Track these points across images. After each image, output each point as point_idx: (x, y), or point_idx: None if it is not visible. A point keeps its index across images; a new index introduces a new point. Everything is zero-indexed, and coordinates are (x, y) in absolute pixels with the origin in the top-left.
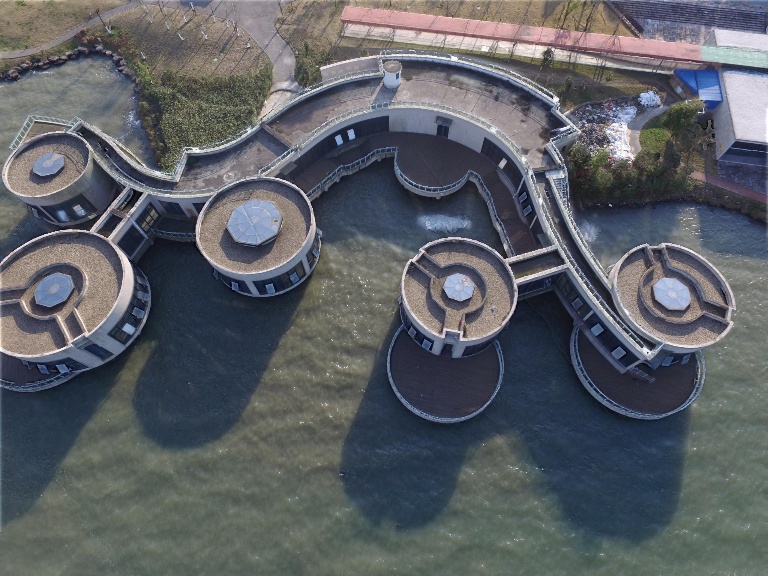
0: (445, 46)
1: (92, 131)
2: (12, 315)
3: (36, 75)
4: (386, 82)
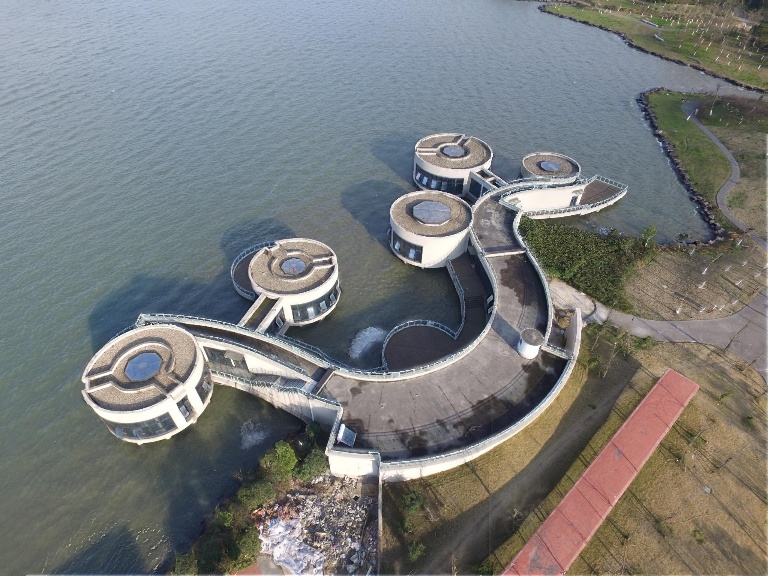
0: None
1: None
2: None
3: (694, 208)
4: None
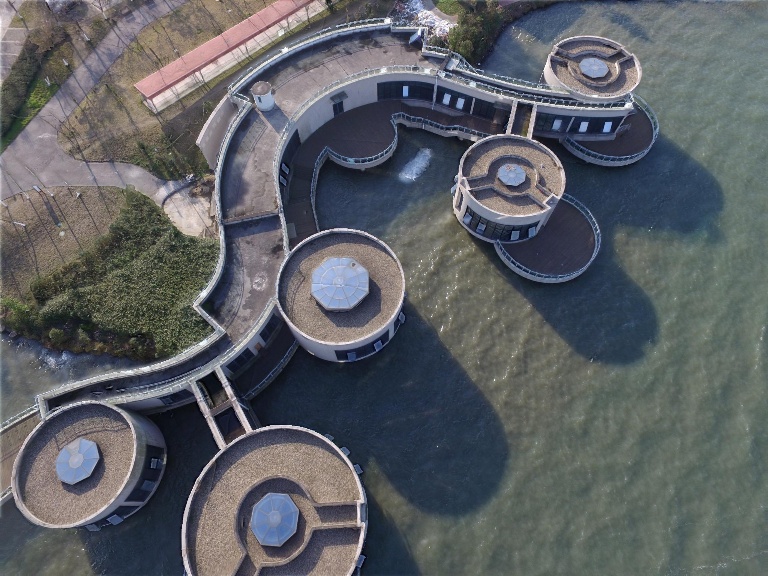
0: (250, 54)
1: (67, 392)
2: None
3: None
4: (265, 106)
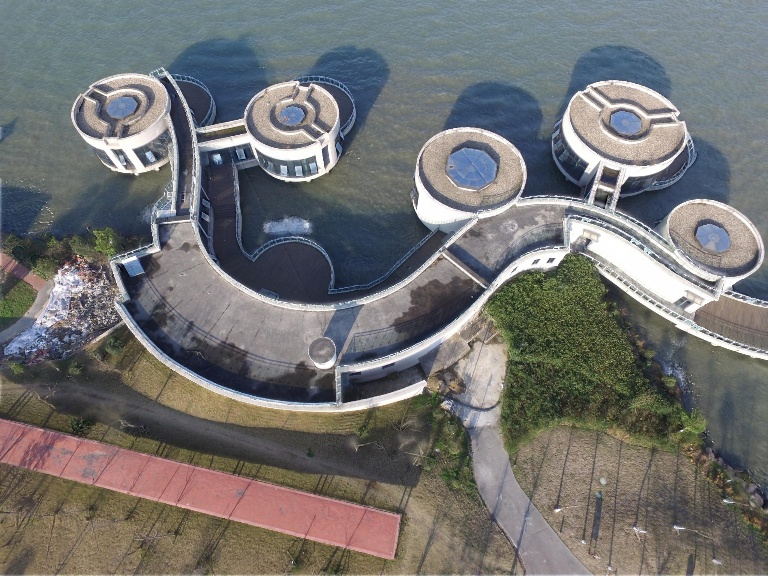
0: None
1: None
2: (649, 110)
3: None
4: None
